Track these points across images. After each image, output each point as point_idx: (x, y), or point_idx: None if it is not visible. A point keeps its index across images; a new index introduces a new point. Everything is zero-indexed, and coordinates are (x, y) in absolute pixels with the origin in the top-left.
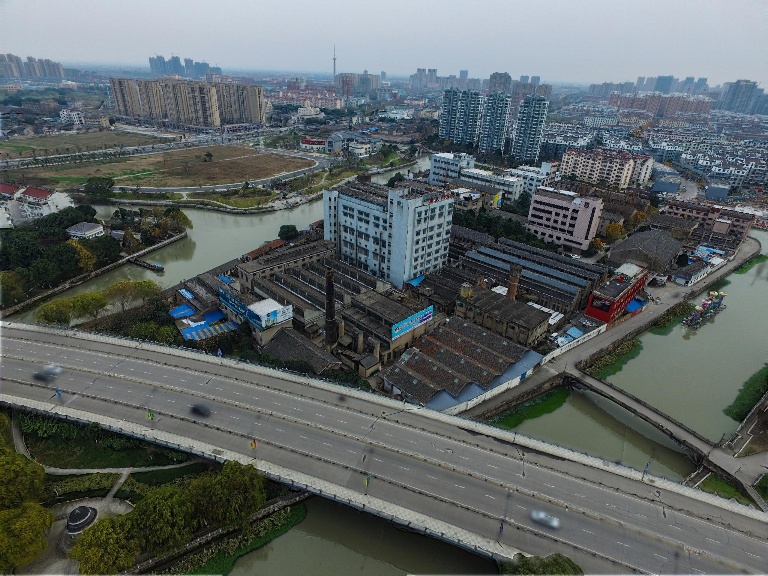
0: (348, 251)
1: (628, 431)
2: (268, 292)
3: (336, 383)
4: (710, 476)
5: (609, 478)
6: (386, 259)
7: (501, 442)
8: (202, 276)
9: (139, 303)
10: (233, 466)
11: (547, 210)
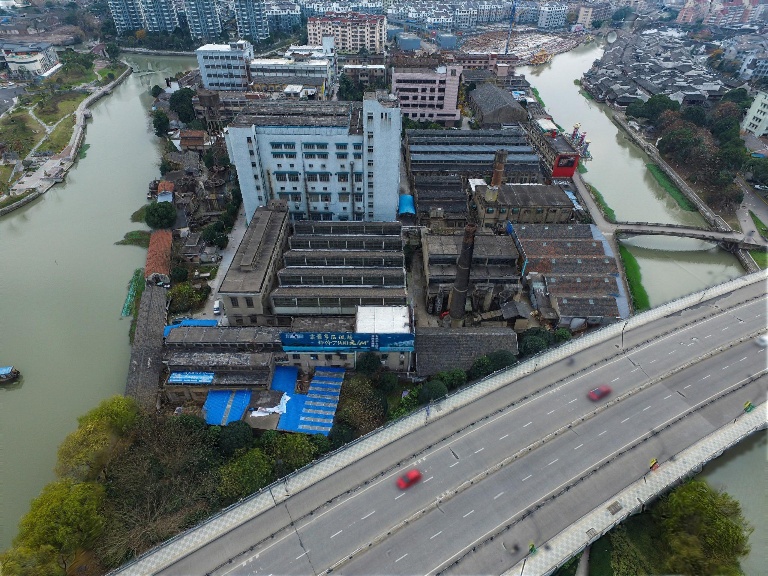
0: (290, 205)
1: (665, 253)
2: (314, 303)
3: (548, 350)
4: (750, 253)
5: (759, 287)
6: (366, 195)
7: (696, 308)
8: (176, 338)
9: (117, 446)
10: (701, 500)
11: (412, 88)
